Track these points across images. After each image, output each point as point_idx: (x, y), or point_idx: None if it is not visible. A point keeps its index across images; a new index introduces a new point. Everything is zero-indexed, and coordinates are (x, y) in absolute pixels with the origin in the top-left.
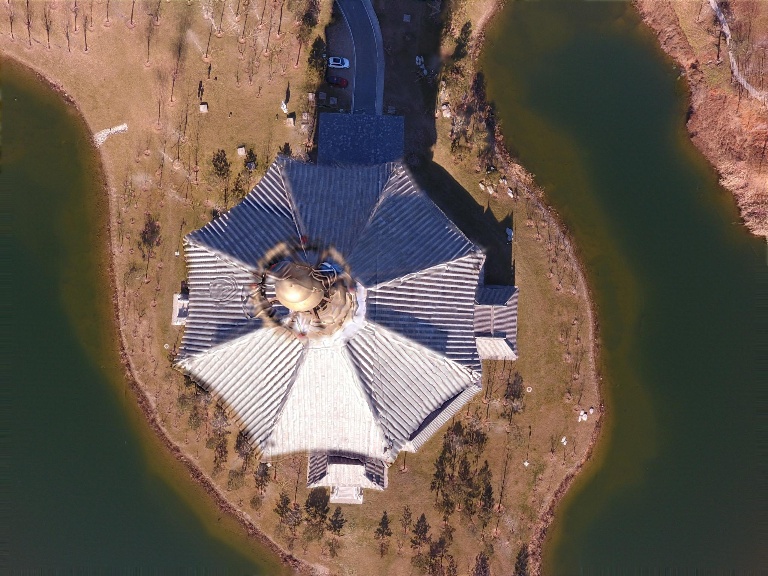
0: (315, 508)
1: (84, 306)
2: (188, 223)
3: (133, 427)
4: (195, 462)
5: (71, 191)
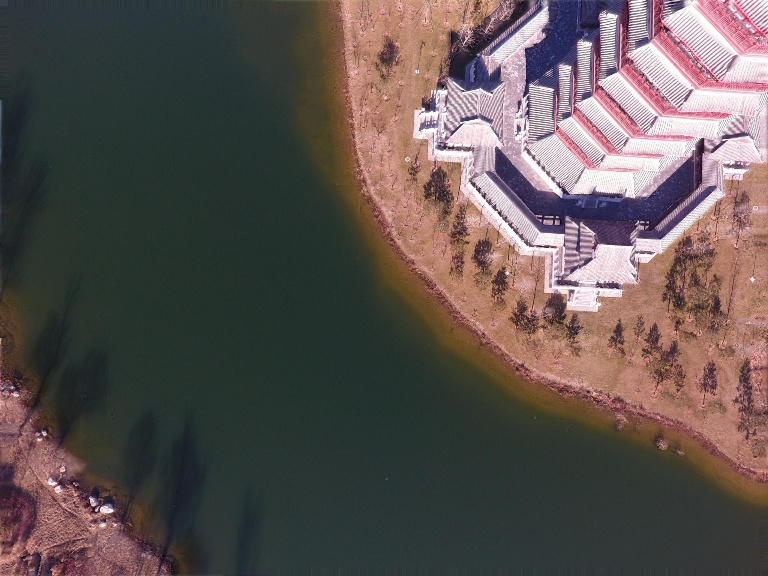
0: (552, 314)
1: (318, 127)
2: (427, 43)
3: (367, 242)
4: (430, 274)
5: (304, 19)
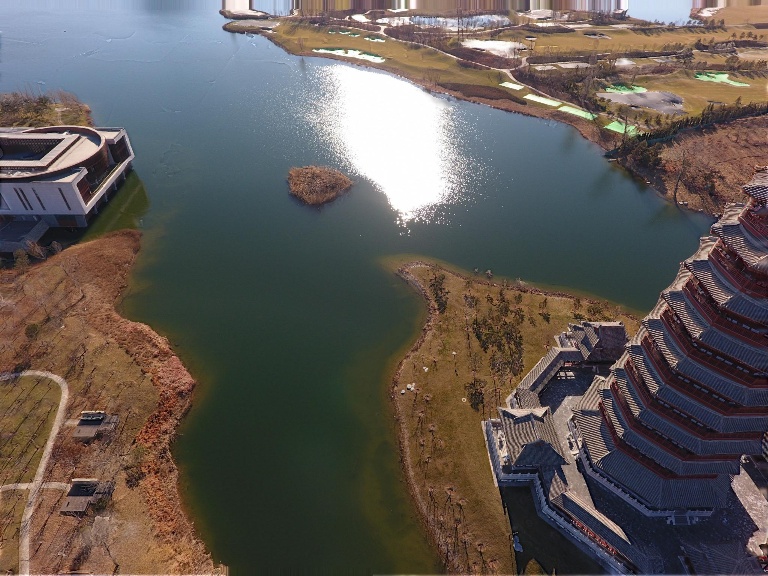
0: None
1: None
2: None
3: None
4: None
5: None
